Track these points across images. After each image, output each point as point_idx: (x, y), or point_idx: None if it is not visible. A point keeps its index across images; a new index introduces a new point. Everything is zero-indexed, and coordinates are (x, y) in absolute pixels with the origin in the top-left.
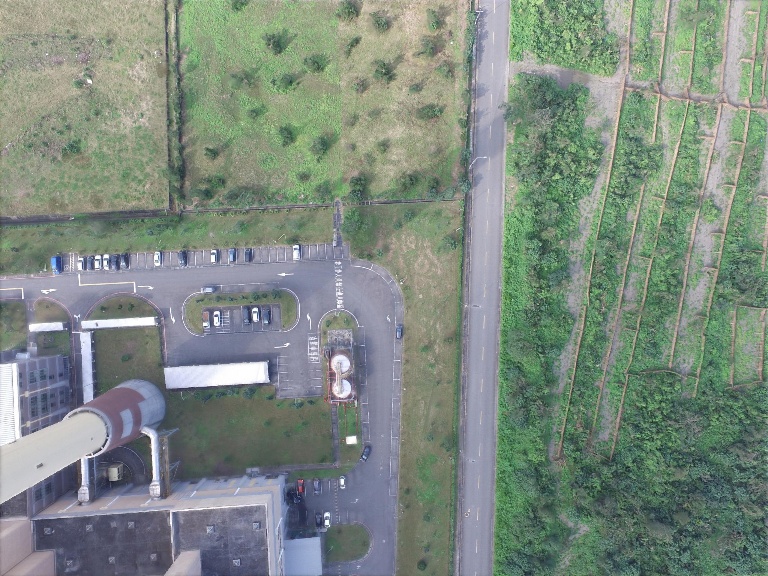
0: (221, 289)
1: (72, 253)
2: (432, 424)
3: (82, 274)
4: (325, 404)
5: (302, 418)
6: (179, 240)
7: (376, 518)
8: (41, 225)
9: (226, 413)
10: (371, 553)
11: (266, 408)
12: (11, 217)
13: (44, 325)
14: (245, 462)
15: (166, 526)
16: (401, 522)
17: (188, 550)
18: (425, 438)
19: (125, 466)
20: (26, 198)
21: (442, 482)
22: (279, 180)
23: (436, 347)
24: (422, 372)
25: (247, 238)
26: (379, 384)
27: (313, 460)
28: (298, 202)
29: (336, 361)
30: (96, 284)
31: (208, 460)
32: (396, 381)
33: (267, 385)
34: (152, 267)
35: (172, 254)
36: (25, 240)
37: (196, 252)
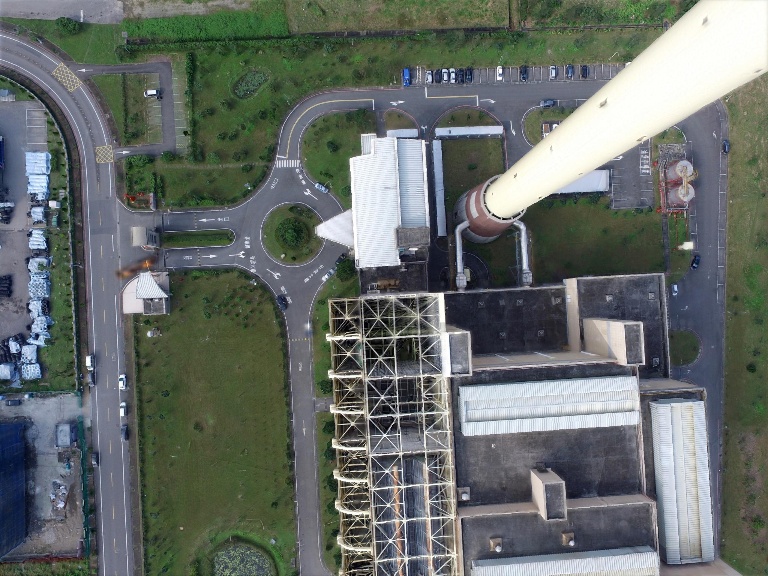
0: (558, 104)
1: (419, 67)
2: (758, 234)
3: (428, 87)
4: (657, 215)
5: (636, 227)
6: (519, 56)
7: (705, 325)
8: (395, 37)
9: (565, 222)
10: (700, 358)
11: (602, 218)
12: (361, 32)
13: (401, 131)
14: (582, 269)
15: (550, 305)
16: (729, 328)
17: (589, 317)
18: (757, 244)
19: (470, 271)
20: (377, 13)
21: (767, 291)
22: (611, 1)
23: (760, 162)
24: (747, 185)
25: (583, 55)
26: (706, 197)
27: (646, 268)
28: (632, 20)
29: (682, 165)
30: (441, 97)
31: (548, 266)
32: (722, 194)
33: (602, 196)
34: (493, 82)
35: (512, 70)
36: (376, 53)
37: (535, 68)
